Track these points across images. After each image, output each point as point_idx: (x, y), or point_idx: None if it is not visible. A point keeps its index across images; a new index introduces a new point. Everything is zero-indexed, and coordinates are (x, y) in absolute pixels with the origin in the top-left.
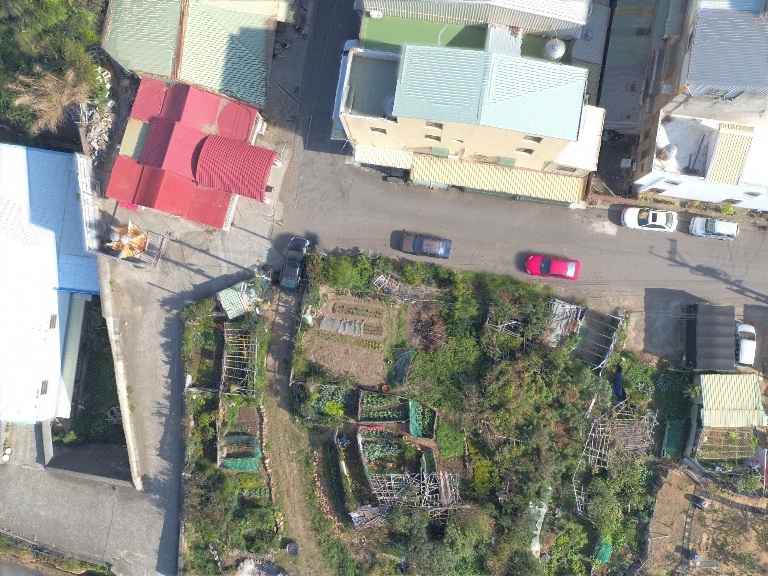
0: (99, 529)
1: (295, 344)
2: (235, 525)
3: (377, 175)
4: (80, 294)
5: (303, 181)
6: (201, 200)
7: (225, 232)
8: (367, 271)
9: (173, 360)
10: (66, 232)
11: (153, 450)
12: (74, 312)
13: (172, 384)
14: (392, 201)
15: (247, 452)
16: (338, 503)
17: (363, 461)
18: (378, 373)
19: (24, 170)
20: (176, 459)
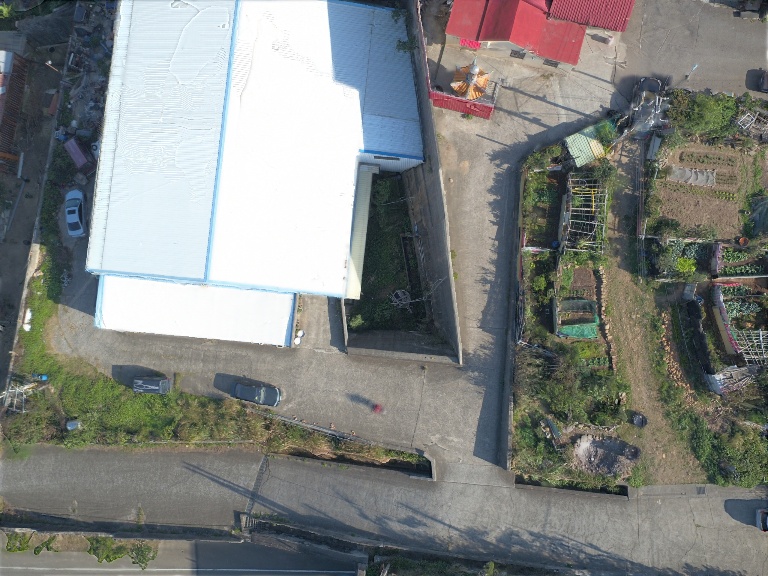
0: (407, 413)
1: (651, 192)
2: (583, 393)
3: (728, 11)
4: (367, 166)
5: (647, 20)
6: (552, 35)
7: (563, 77)
8: (730, 110)
9: (501, 220)
10: (369, 91)
11: (474, 322)
12: (361, 186)
13: (499, 247)
14: (746, 38)
15: (583, 318)
16: (691, 369)
17: (724, 319)
18: (733, 225)
19: (325, 23)
20: (500, 331)
